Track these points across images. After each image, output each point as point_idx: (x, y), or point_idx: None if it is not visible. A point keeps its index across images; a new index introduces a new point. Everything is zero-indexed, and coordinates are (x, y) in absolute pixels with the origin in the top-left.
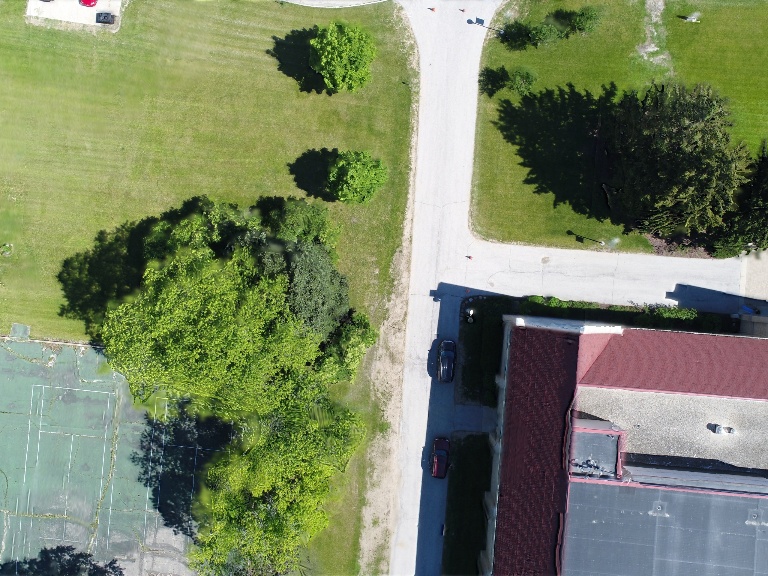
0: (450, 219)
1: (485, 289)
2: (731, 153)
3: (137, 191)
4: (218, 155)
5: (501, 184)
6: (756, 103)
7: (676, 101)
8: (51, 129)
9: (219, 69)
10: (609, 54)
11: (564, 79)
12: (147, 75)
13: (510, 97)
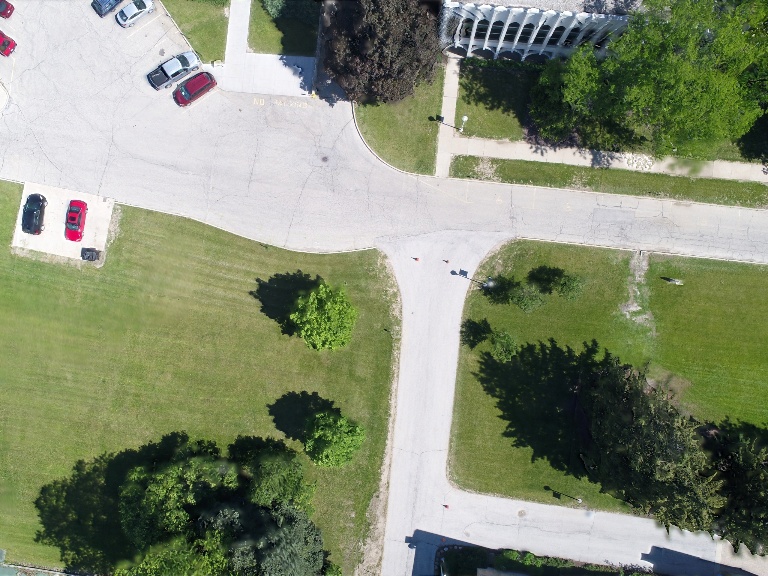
0: (428, 467)
1: (461, 539)
2: (703, 491)
3: (116, 423)
4: (198, 392)
5: (480, 435)
6: (737, 367)
7: (651, 420)
8: (33, 358)
9: (202, 308)
10: (592, 311)
11: (546, 334)
12: (130, 310)
13: (491, 350)
